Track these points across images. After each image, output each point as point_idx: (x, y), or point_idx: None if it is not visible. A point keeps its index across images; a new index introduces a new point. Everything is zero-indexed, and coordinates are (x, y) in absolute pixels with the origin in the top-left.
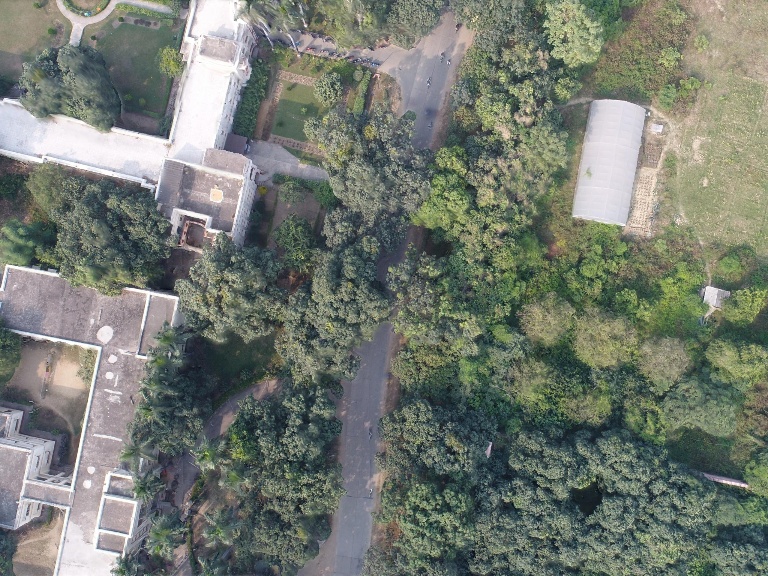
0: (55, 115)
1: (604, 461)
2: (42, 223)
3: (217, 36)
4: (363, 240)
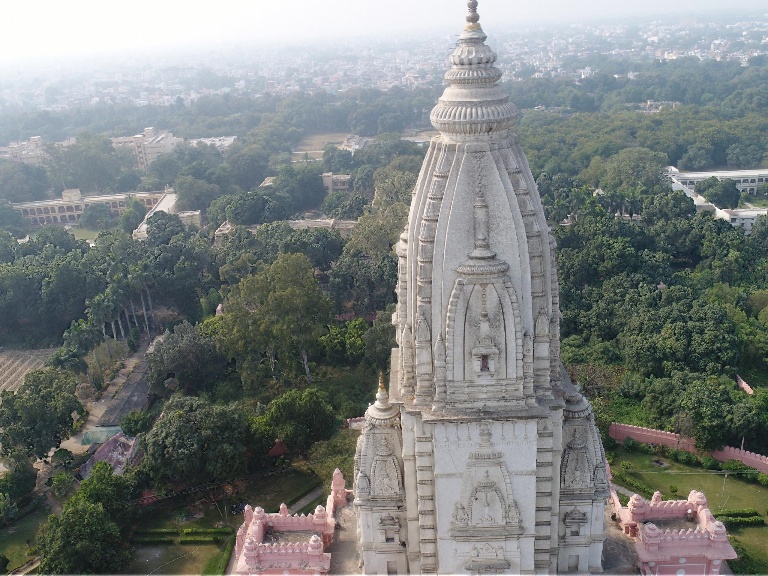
0: None
1: None
2: None
3: None
4: None
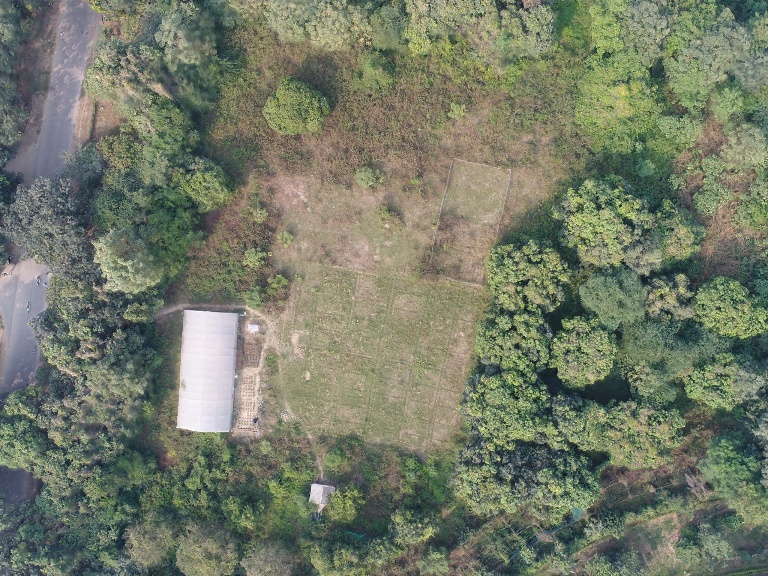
0: None
1: None
2: None
3: None
4: None
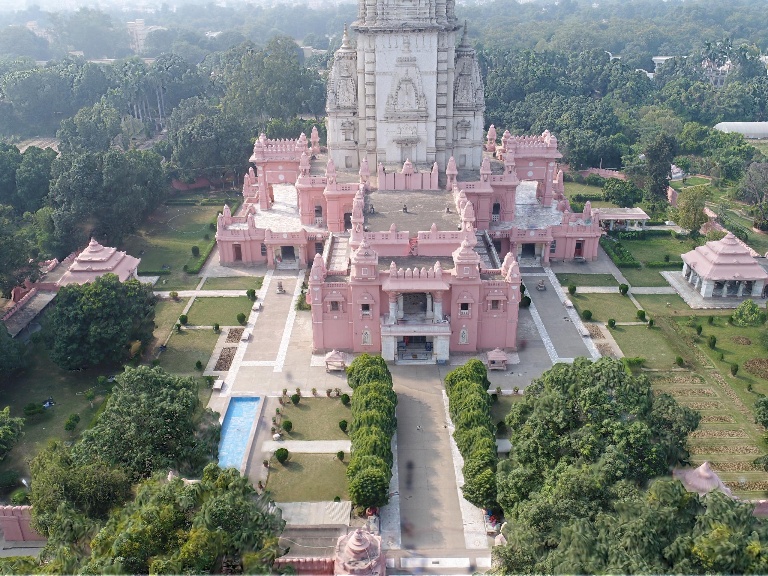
0: None
1: None
2: None
3: None
4: None
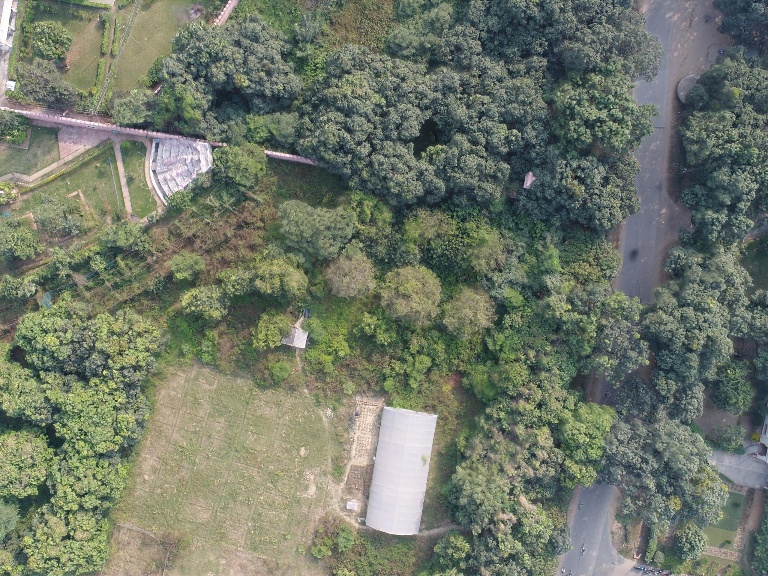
0: None
1: (419, 174)
2: None
3: None
4: None
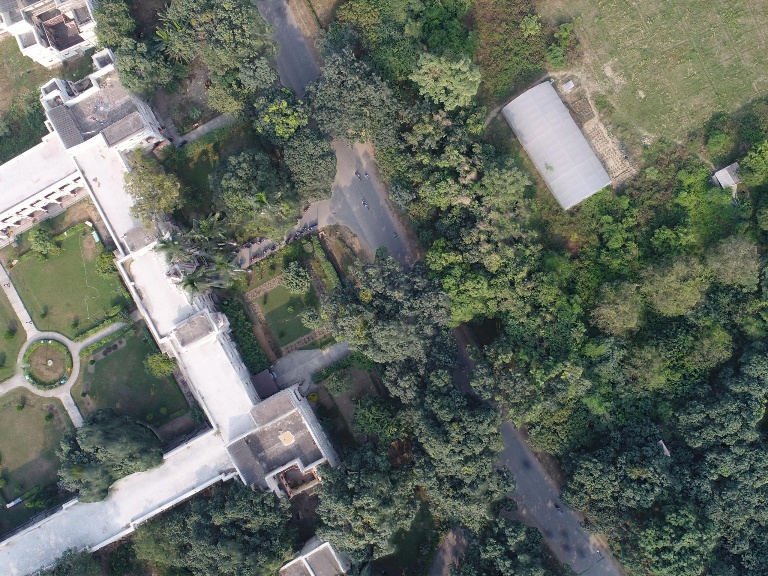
0: (112, 485)
1: (762, 383)
2: (169, 569)
3: (182, 320)
4: (432, 380)
